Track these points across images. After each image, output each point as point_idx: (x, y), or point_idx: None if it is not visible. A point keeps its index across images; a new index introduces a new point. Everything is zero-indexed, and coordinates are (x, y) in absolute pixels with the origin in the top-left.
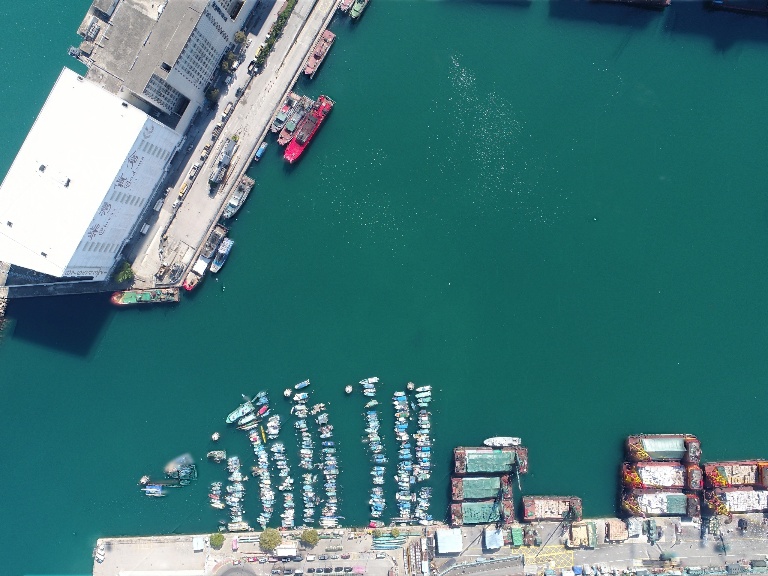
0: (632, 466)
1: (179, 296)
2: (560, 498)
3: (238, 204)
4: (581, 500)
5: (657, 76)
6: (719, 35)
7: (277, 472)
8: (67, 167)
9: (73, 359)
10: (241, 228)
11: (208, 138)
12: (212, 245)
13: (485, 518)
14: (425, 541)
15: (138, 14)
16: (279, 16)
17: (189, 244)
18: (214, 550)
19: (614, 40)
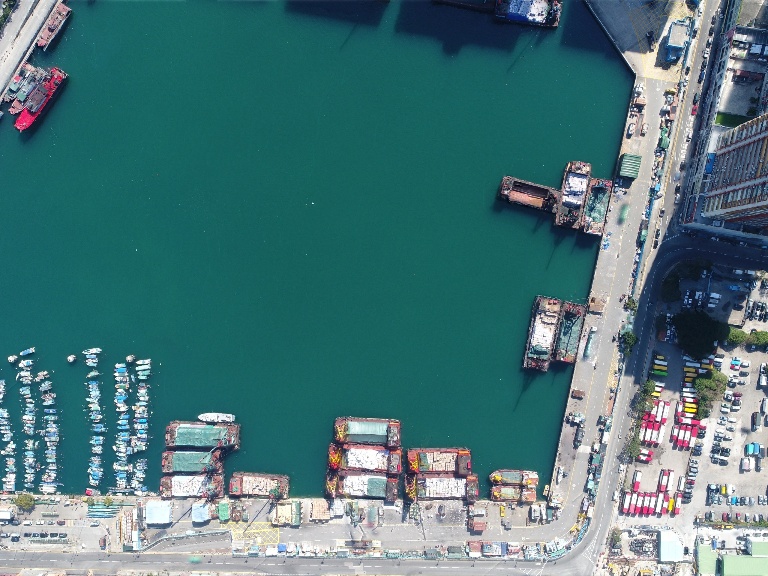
0: (338, 448)
1: None
2: (269, 476)
3: None
4: (288, 479)
5: (379, 66)
6: (441, 28)
7: (1, 437)
8: None
9: None
10: None
11: None
12: None
13: (194, 492)
14: (136, 511)
15: None
16: None
17: None
18: None
19: (339, 28)
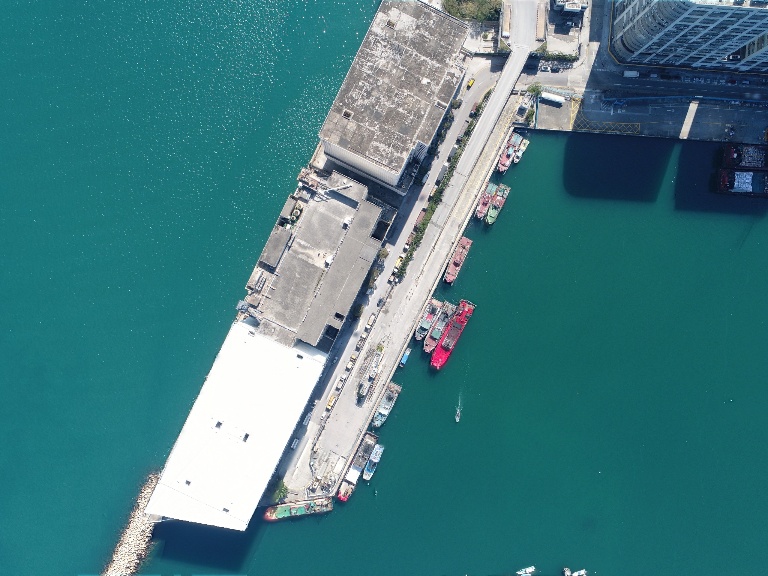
0: None
1: (332, 505)
2: None
3: (388, 412)
4: None
5: None
6: None
7: None
8: (244, 422)
9: (227, 575)
10: (390, 433)
11: (352, 349)
12: (365, 455)
13: None
14: None
15: (304, 263)
16: (417, 227)
17: (339, 454)
18: None
19: (738, 230)
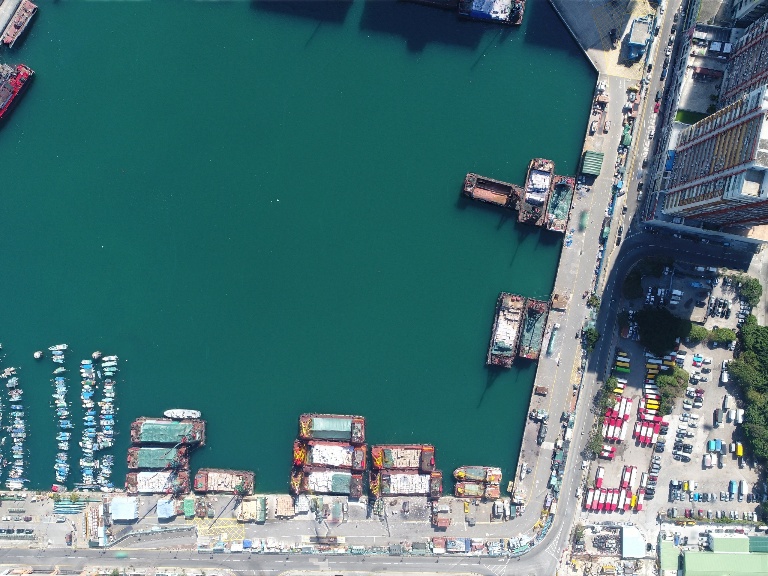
0: (303, 444)
1: None
2: (234, 472)
3: None
4: (253, 475)
5: (344, 63)
6: (405, 26)
7: None
8: None
9: None
10: None
11: None
12: None
13: (160, 488)
14: (102, 507)
15: None
16: None
17: None
18: None
19: (304, 25)
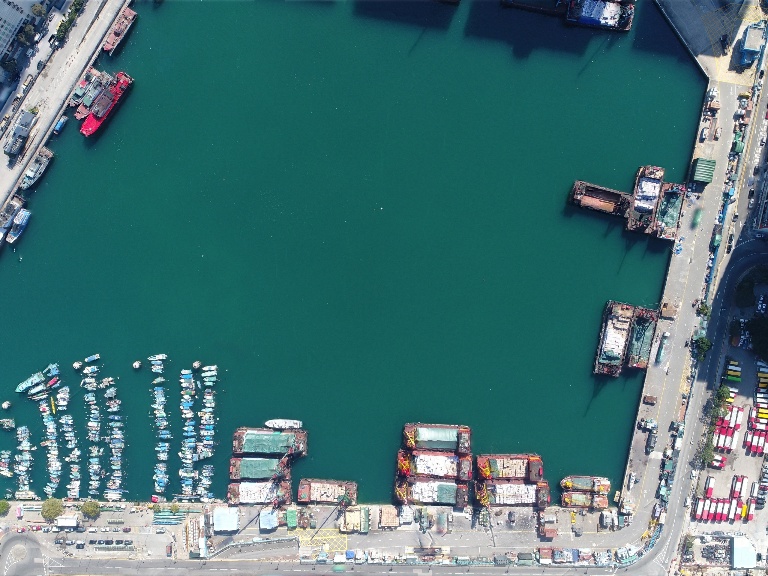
0: (407, 454)
1: None
2: (337, 482)
3: (34, 176)
4: (356, 485)
5: (449, 70)
6: (511, 32)
7: (65, 443)
8: None
9: None
10: (39, 200)
11: (9, 109)
12: (6, 215)
13: (262, 498)
14: (203, 518)
15: None
16: None
17: None
18: None
19: (408, 32)
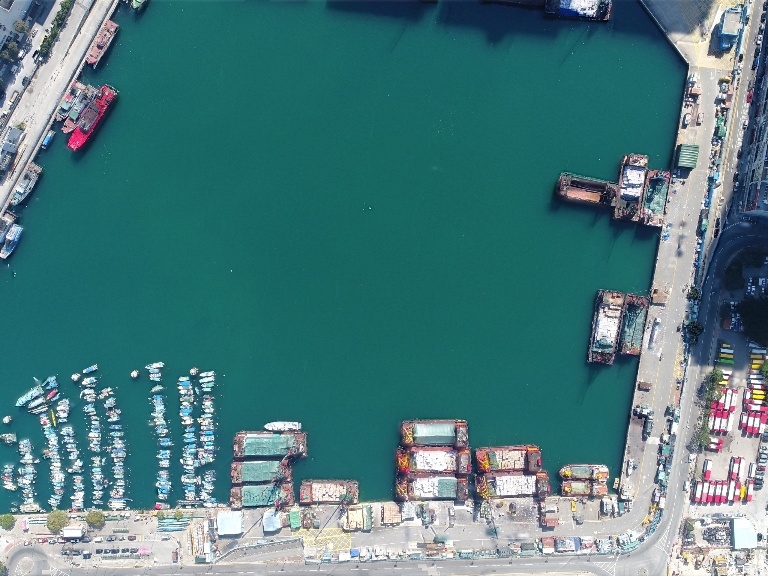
0: (406, 451)
1: None
2: (338, 482)
3: (25, 191)
4: (358, 484)
5: (430, 67)
6: (490, 27)
7: (67, 455)
8: None
9: None
10: (31, 215)
11: None
12: None
13: (264, 501)
14: (207, 523)
15: None
16: None
17: None
18: (6, 531)
19: (388, 32)
